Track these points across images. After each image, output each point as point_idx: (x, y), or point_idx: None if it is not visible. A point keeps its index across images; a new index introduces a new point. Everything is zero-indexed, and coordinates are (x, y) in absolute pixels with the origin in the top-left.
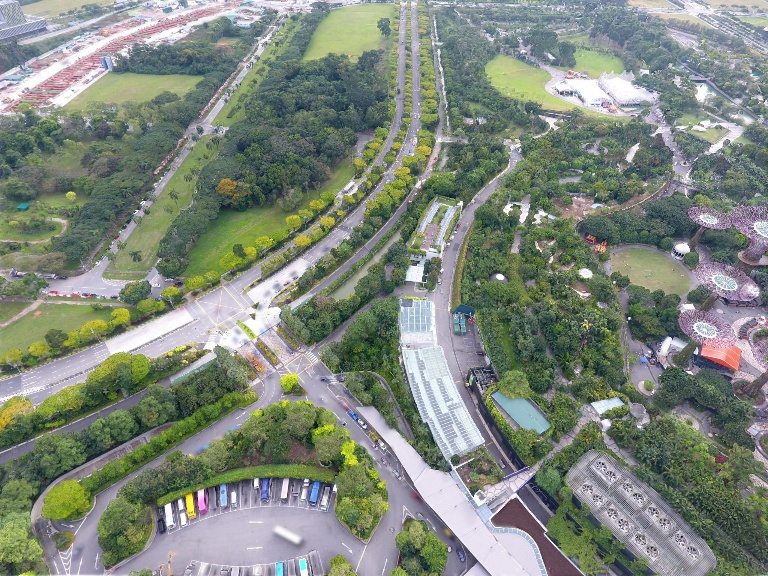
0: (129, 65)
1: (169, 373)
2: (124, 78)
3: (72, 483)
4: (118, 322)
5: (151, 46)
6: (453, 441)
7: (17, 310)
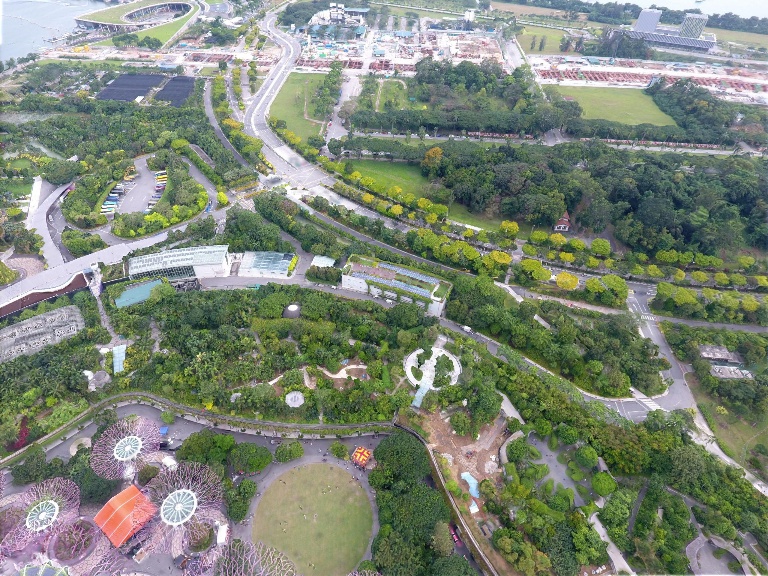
0: (658, 91)
1: (252, 164)
2: (637, 97)
3: (186, 143)
4: (291, 140)
5: (698, 87)
6: (140, 261)
7: (317, 119)
